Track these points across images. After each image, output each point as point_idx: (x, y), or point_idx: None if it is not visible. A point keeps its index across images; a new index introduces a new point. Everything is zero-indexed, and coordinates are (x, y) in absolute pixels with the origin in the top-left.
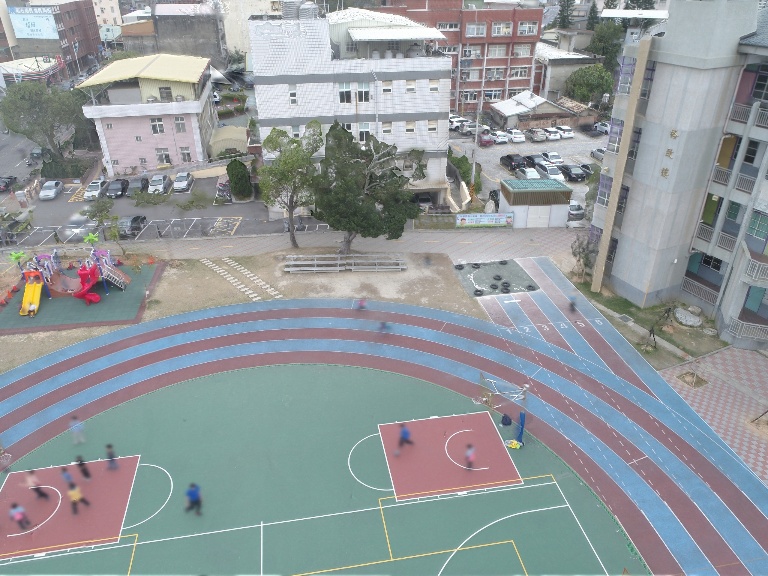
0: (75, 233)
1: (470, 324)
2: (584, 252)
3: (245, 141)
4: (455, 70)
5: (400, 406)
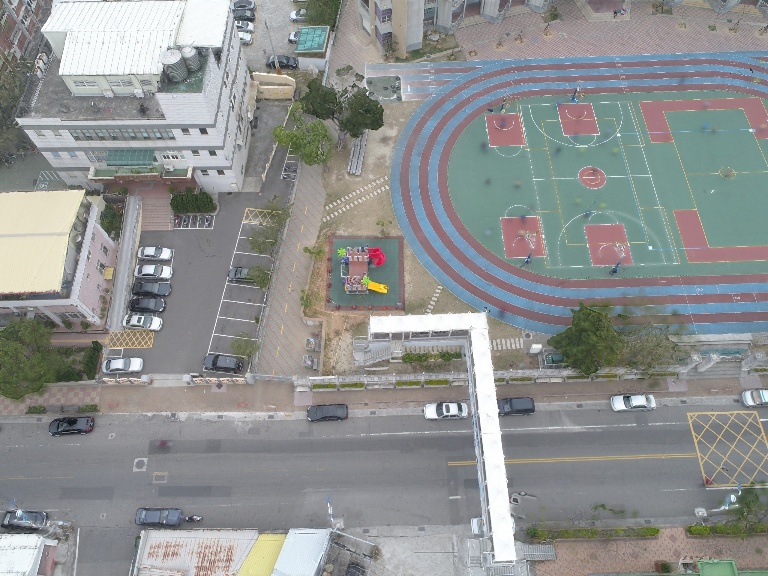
0: (235, 319)
1: (426, 107)
2: (389, 47)
3: (100, 200)
4: (5, 7)
5: (480, 139)
